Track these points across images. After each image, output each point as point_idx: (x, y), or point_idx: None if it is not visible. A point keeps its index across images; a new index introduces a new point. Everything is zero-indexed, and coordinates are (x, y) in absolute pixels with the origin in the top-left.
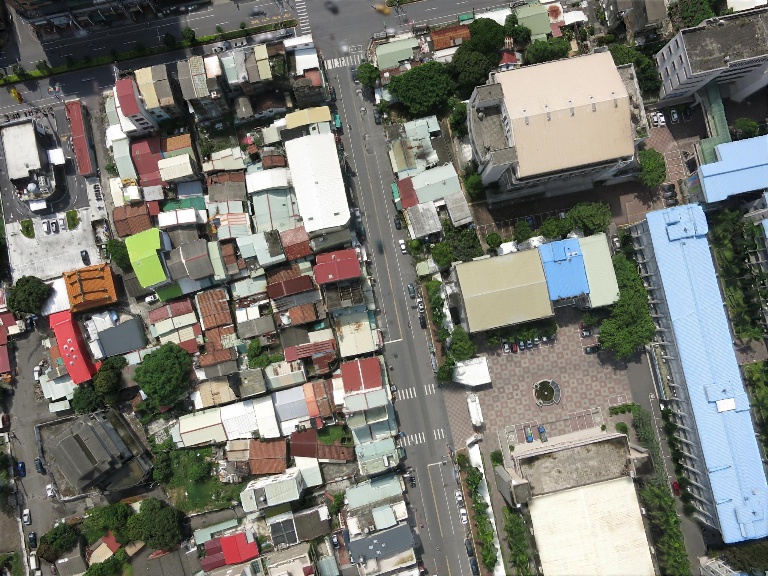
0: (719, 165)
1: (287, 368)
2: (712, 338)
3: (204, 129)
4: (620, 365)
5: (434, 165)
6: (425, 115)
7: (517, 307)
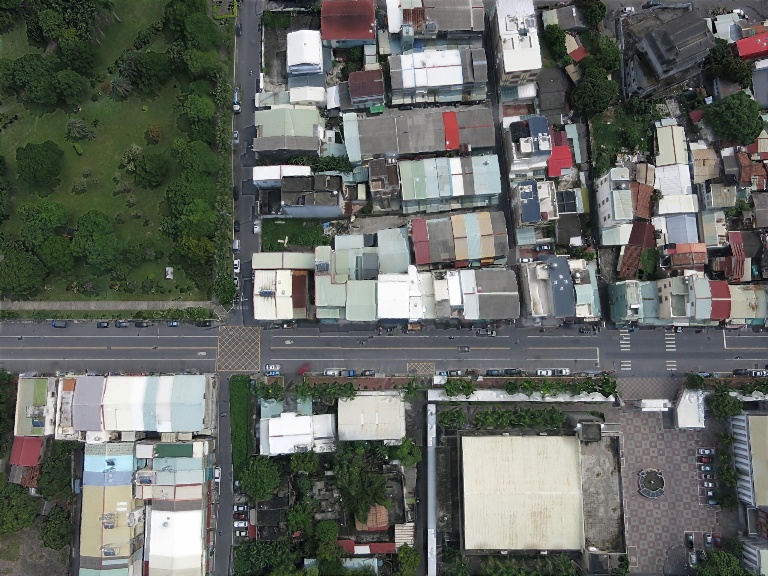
0: None
1: (722, 232)
2: None
3: None
4: (669, 568)
5: None
6: None
7: None
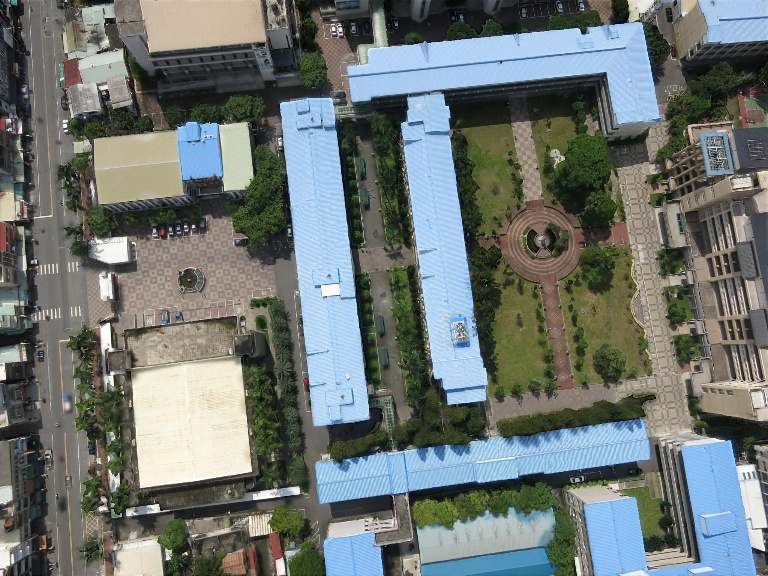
0: (365, 67)
1: None
2: (326, 225)
3: None
4: (269, 260)
5: (104, 49)
6: (102, 2)
7: (149, 184)
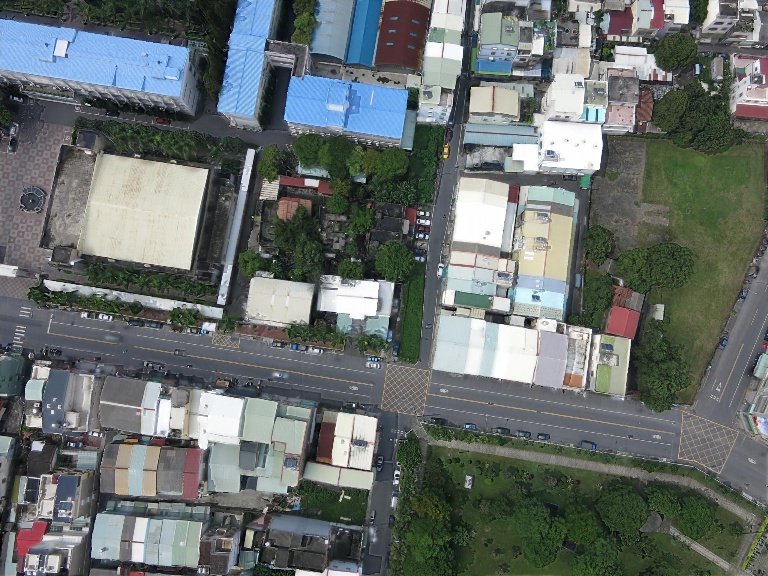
0: None
1: None
2: None
3: None
4: (38, 126)
5: None
6: None
7: None
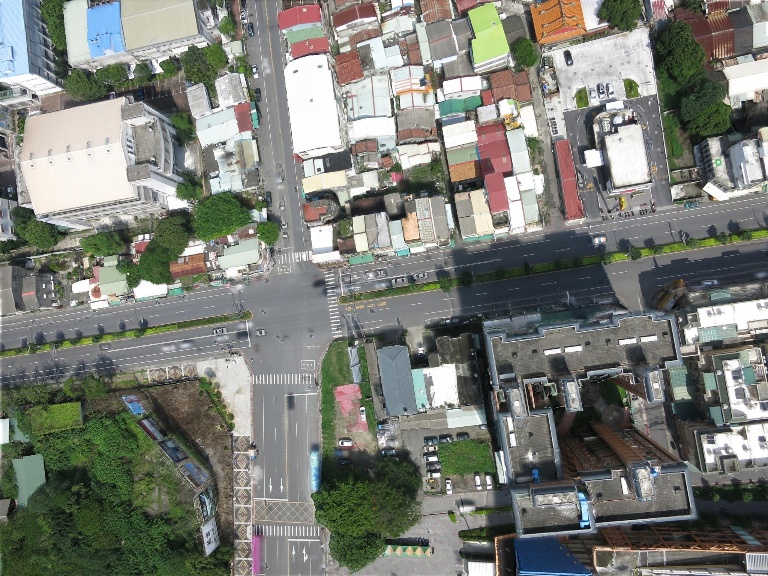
0: None
1: None
2: None
3: (440, 191)
4: None
5: (217, 145)
6: None
7: None
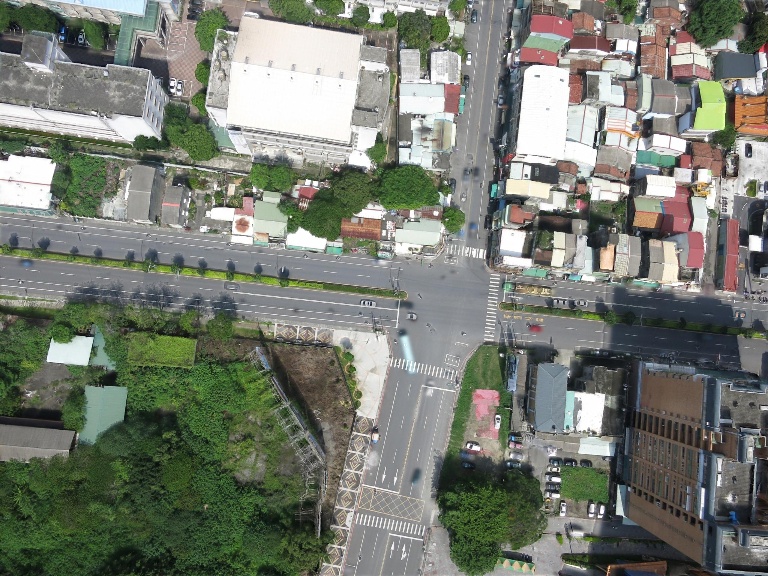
0: None
1: None
2: None
3: None
4: None
5: (418, 116)
6: None
7: None
